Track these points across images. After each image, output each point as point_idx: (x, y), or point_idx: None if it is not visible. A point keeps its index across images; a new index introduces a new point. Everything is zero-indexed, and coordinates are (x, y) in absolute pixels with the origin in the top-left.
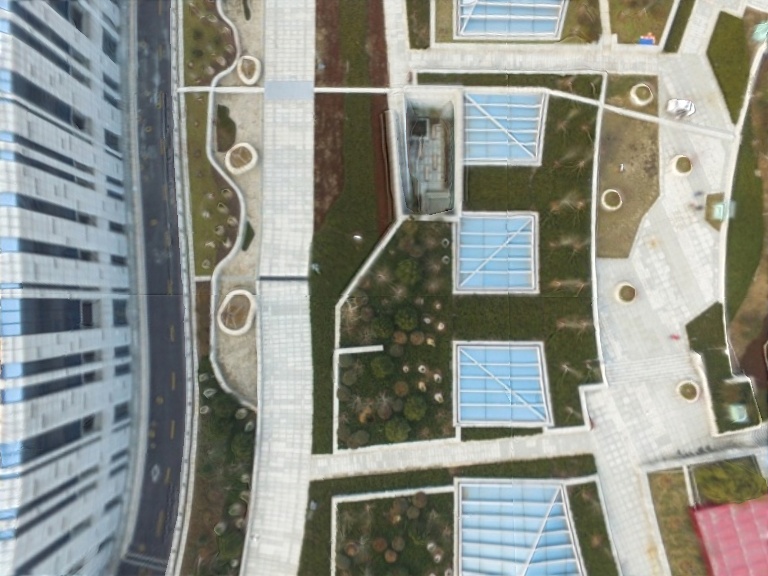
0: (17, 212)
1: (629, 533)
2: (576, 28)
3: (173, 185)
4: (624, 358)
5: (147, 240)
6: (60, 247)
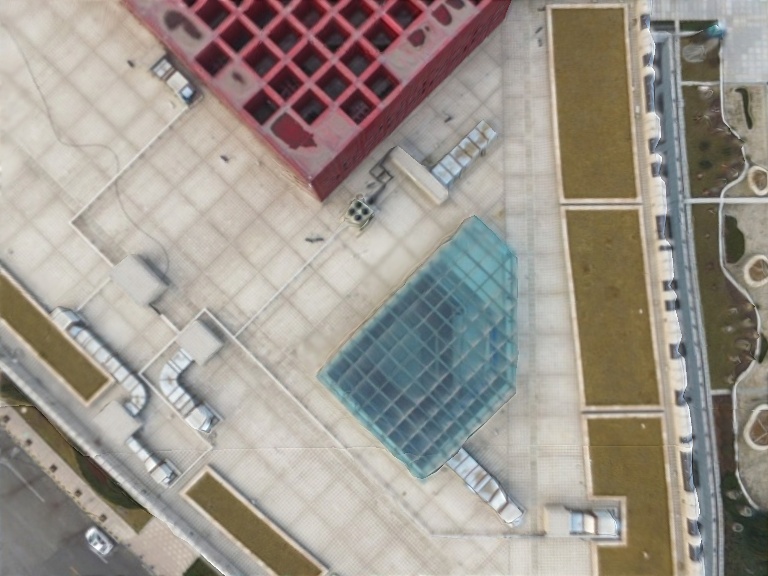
0: (684, 361)
1: None
2: None
3: None
4: None
5: None
6: None
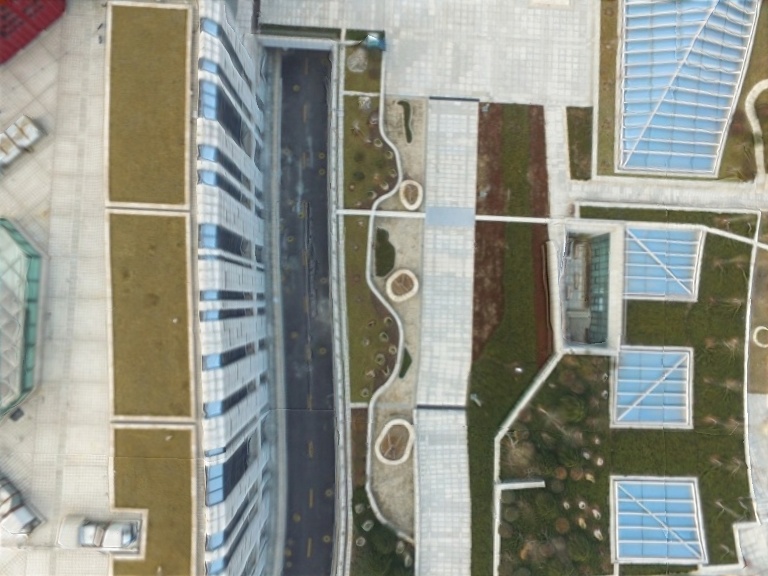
0: (222, 373)
1: None
2: (733, 167)
3: (314, 297)
4: None
5: (287, 353)
6: (239, 390)
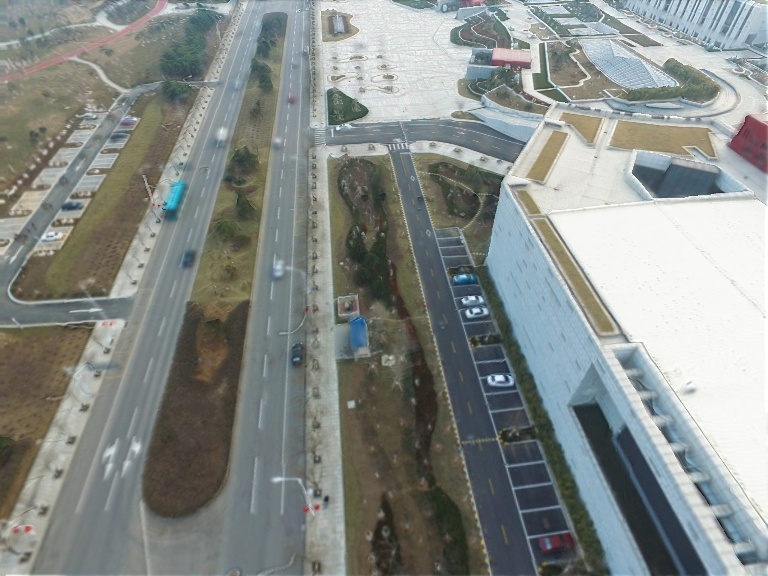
0: None
1: (510, 1)
2: None
3: None
4: None
5: None
6: None
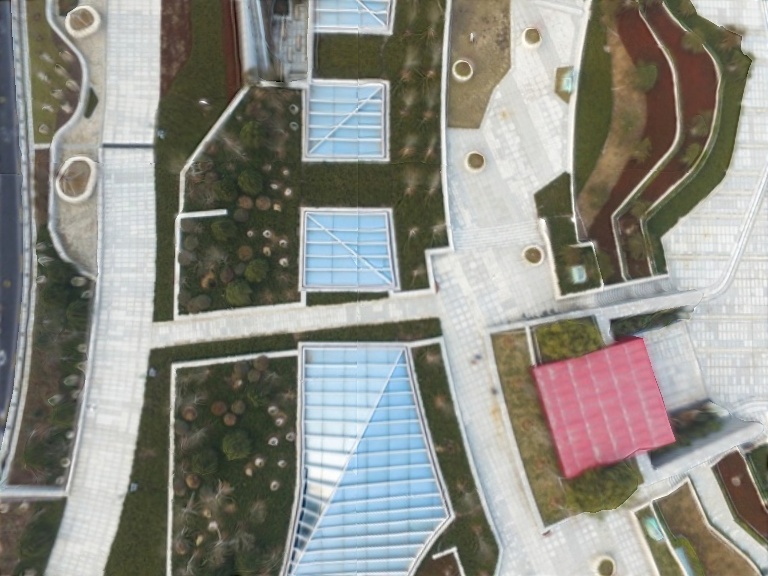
0: None
1: (474, 395)
2: None
3: None
4: (473, 226)
5: None
6: None
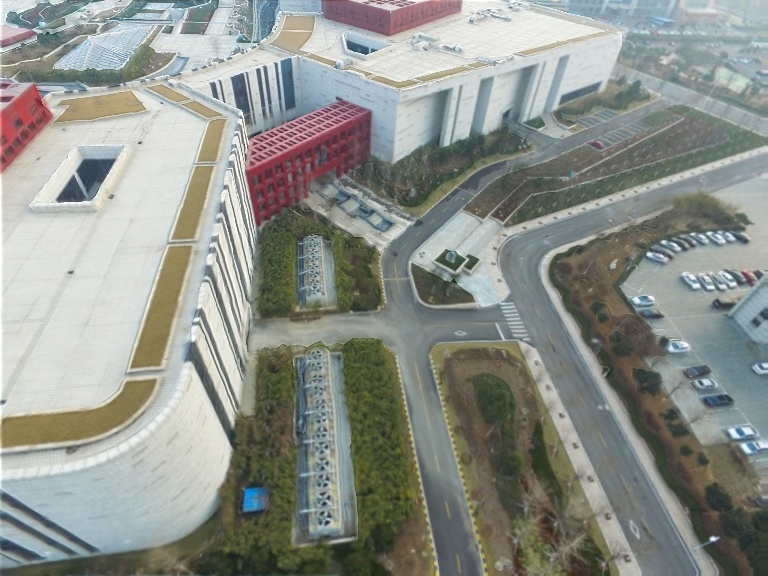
0: None
1: None
2: None
3: (266, 31)
4: None
5: None
6: None
